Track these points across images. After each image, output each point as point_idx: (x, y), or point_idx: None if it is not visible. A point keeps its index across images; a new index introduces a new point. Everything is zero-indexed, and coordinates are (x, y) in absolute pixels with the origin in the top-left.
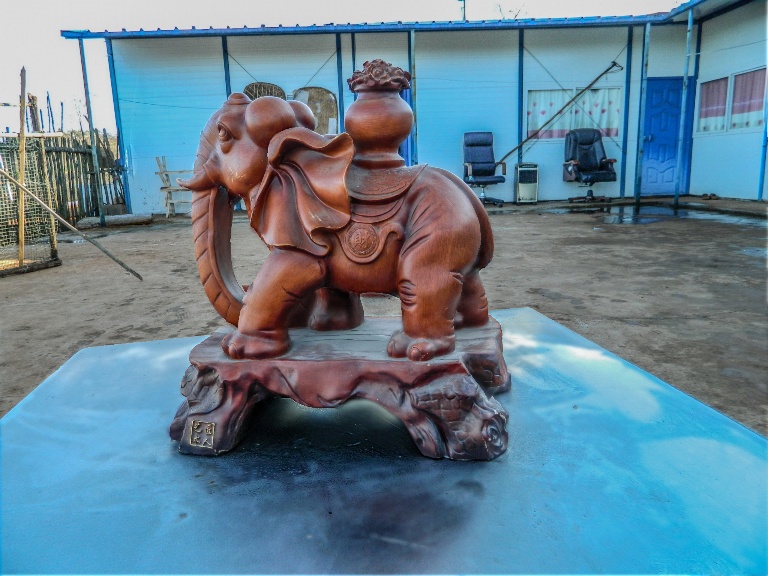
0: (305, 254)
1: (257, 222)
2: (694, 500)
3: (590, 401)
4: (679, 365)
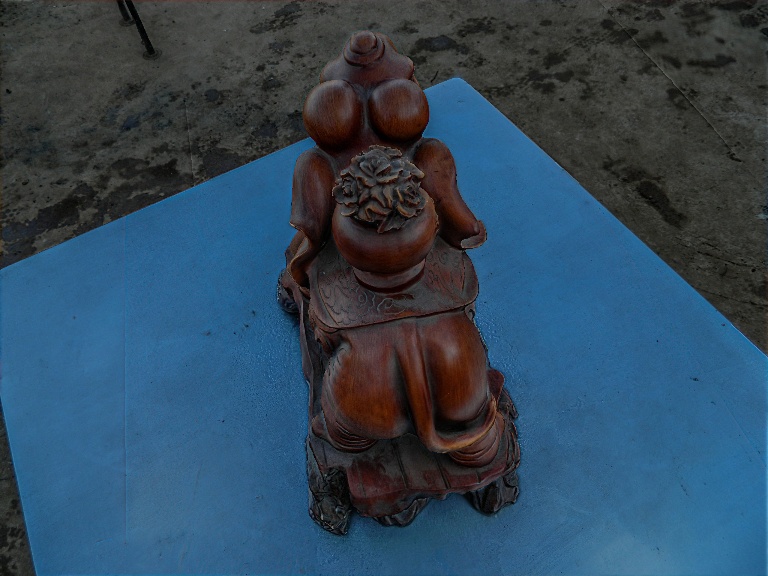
0: None
1: None
2: None
3: None
4: None
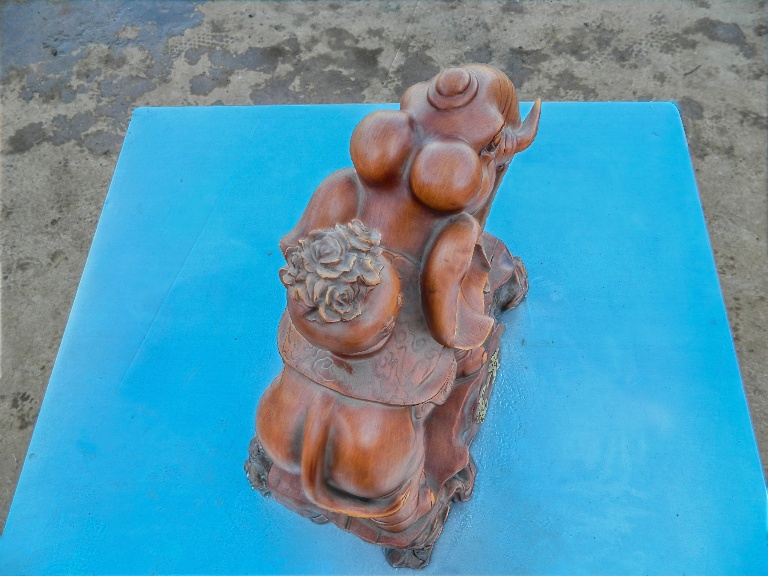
0: None
1: None
2: None
3: None
4: None
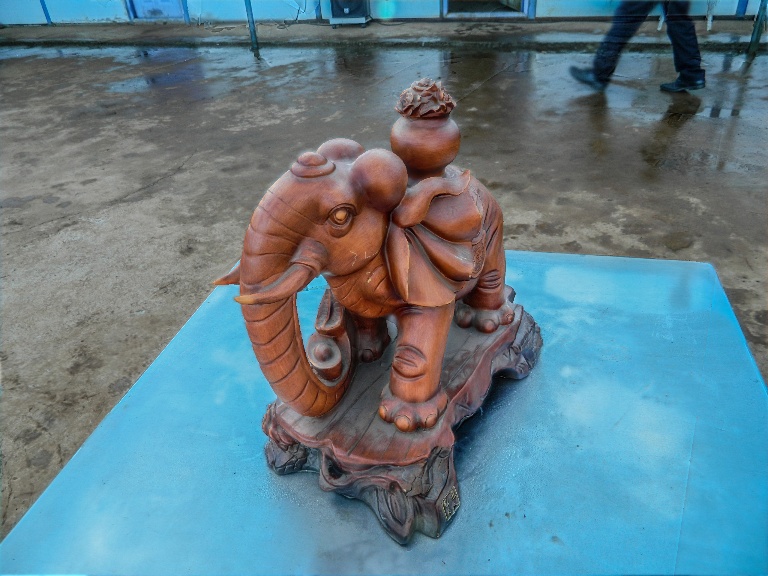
0: None
1: None
2: (608, 301)
3: None
4: (224, 221)
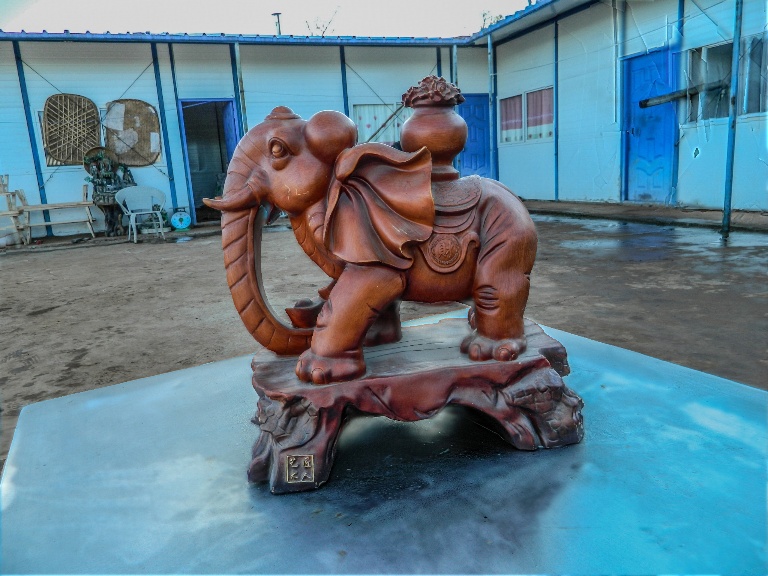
0: (388, 269)
1: (328, 240)
2: (757, 443)
3: (609, 379)
4: None
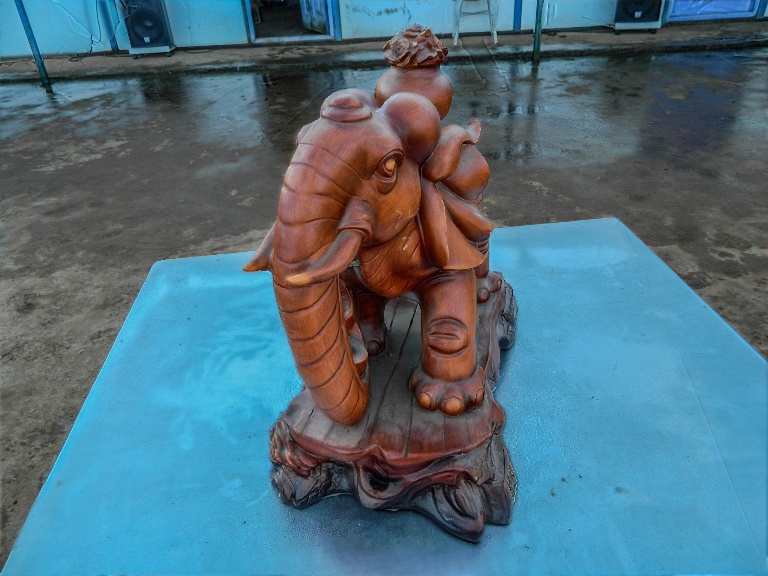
0: None
1: None
2: (550, 263)
3: None
4: (66, 268)
